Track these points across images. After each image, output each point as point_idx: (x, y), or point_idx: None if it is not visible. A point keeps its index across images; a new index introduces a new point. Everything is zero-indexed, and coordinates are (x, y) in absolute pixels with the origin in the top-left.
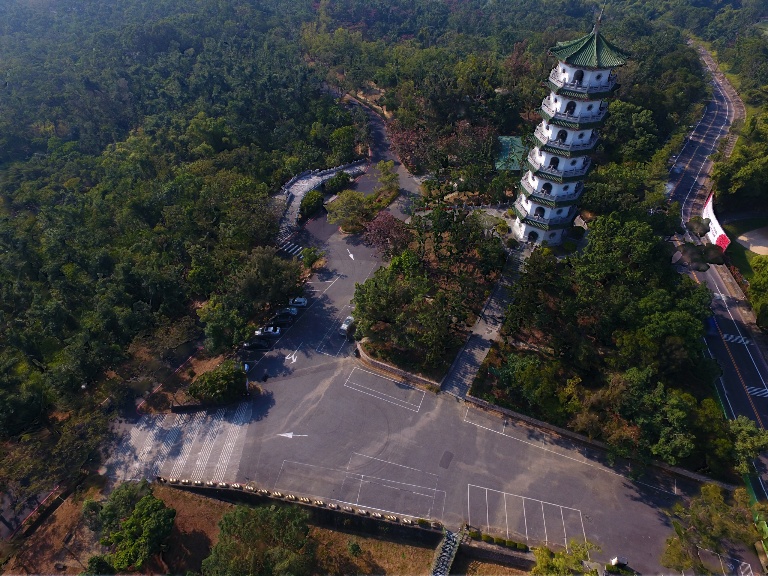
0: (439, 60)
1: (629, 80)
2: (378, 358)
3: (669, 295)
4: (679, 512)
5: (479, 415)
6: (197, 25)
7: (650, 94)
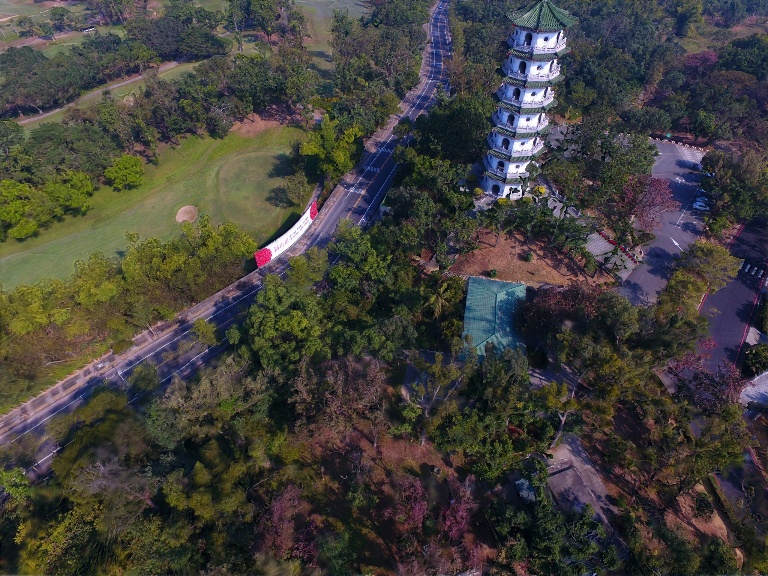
0: None
1: None
2: None
3: None
4: (496, 81)
5: None
6: None
7: None
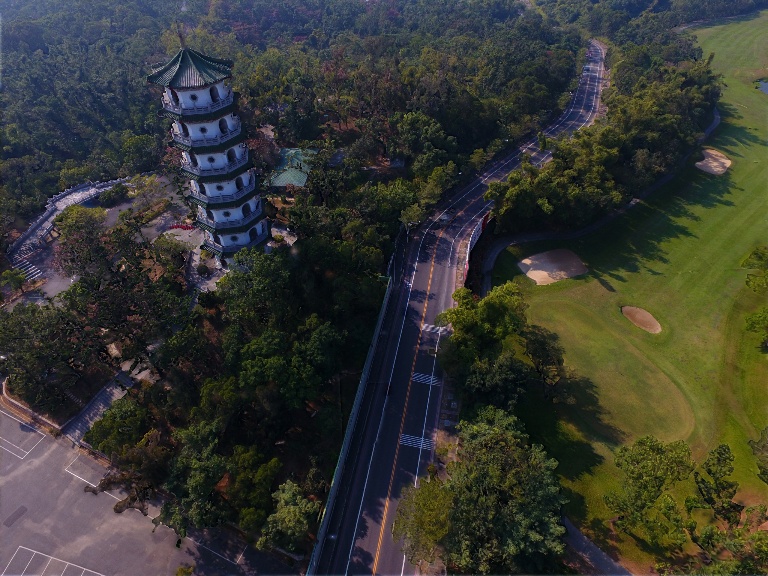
0: (277, 65)
1: (434, 90)
2: (15, 396)
3: (289, 337)
4: None
5: (85, 464)
6: (66, 25)
7: (470, 105)
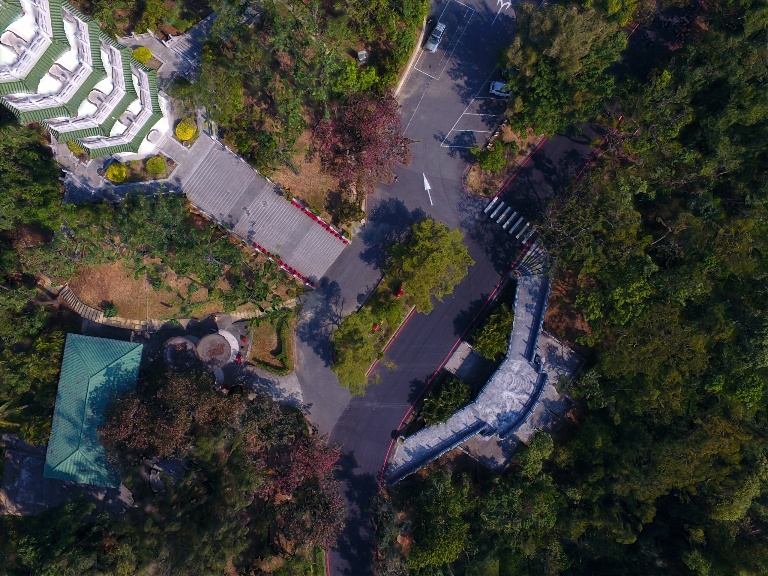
0: None
1: None
2: None
3: None
4: None
5: None
6: None
7: None
